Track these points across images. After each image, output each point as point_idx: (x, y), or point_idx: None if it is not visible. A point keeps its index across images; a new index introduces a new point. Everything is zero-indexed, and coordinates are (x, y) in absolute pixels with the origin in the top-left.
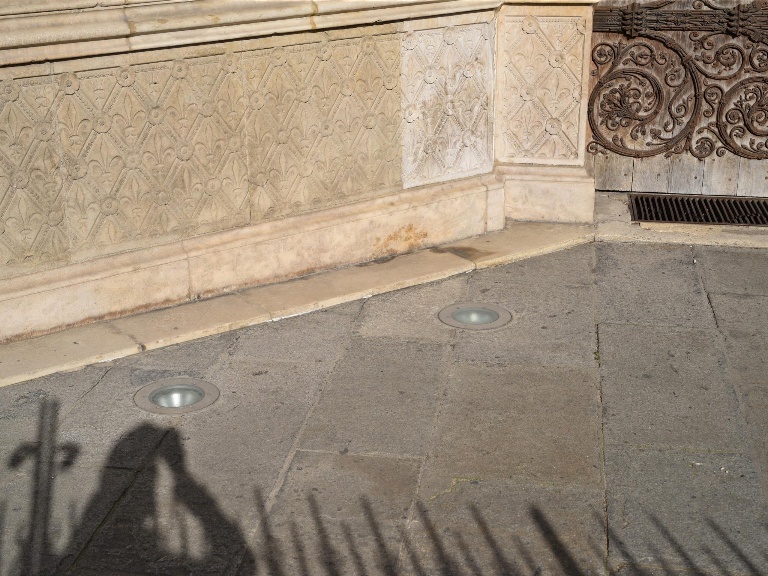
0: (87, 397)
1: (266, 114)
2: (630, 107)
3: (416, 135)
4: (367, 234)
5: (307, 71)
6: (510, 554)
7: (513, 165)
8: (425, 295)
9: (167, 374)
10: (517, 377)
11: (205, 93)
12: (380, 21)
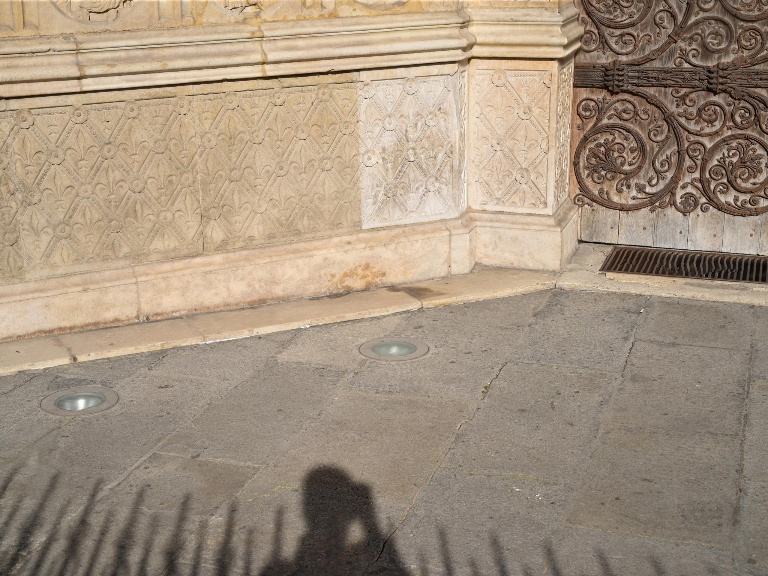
0: (2, 397)
1: (219, 153)
2: (615, 161)
3: (376, 179)
4: (321, 270)
5: (260, 115)
6: (286, 552)
7: (485, 212)
8: (358, 328)
9: (84, 382)
10: (397, 404)
11: (157, 132)
12: (333, 70)
